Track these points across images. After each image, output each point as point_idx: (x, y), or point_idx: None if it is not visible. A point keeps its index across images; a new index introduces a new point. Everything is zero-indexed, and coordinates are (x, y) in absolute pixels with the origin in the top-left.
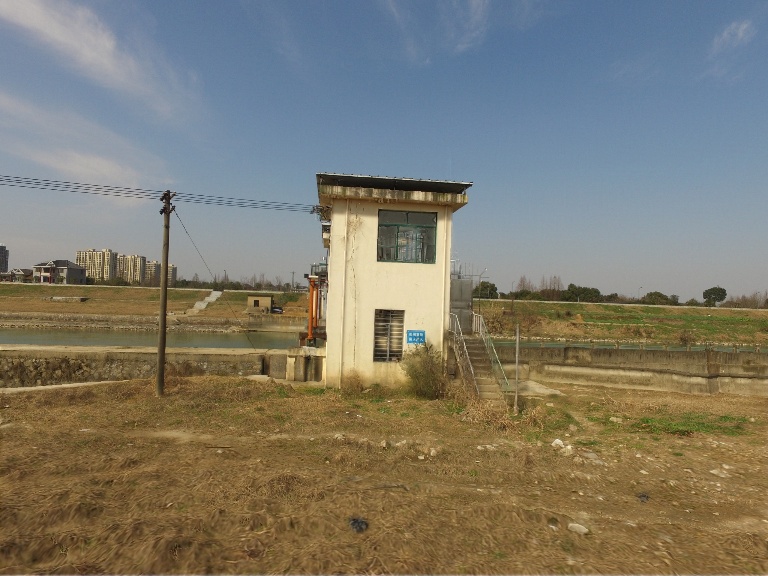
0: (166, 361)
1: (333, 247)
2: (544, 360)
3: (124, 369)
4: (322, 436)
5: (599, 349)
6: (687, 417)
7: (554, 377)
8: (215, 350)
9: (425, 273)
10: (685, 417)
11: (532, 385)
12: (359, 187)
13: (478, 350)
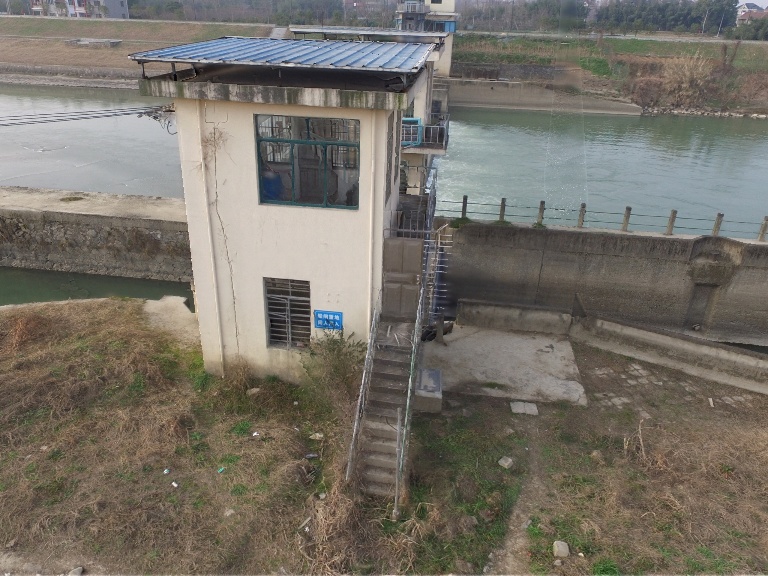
0: (112, 226)
1: (186, 180)
2: (654, 258)
3: (67, 233)
4: (57, 568)
5: (761, 247)
6: (694, 564)
7: (608, 340)
8: (176, 208)
9: (340, 226)
10: (691, 562)
11: (554, 362)
12: (205, 82)
13: (404, 368)
